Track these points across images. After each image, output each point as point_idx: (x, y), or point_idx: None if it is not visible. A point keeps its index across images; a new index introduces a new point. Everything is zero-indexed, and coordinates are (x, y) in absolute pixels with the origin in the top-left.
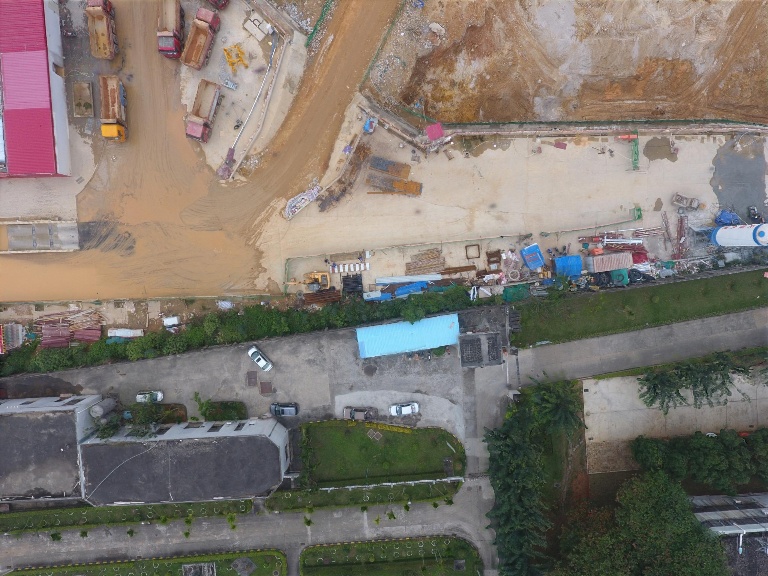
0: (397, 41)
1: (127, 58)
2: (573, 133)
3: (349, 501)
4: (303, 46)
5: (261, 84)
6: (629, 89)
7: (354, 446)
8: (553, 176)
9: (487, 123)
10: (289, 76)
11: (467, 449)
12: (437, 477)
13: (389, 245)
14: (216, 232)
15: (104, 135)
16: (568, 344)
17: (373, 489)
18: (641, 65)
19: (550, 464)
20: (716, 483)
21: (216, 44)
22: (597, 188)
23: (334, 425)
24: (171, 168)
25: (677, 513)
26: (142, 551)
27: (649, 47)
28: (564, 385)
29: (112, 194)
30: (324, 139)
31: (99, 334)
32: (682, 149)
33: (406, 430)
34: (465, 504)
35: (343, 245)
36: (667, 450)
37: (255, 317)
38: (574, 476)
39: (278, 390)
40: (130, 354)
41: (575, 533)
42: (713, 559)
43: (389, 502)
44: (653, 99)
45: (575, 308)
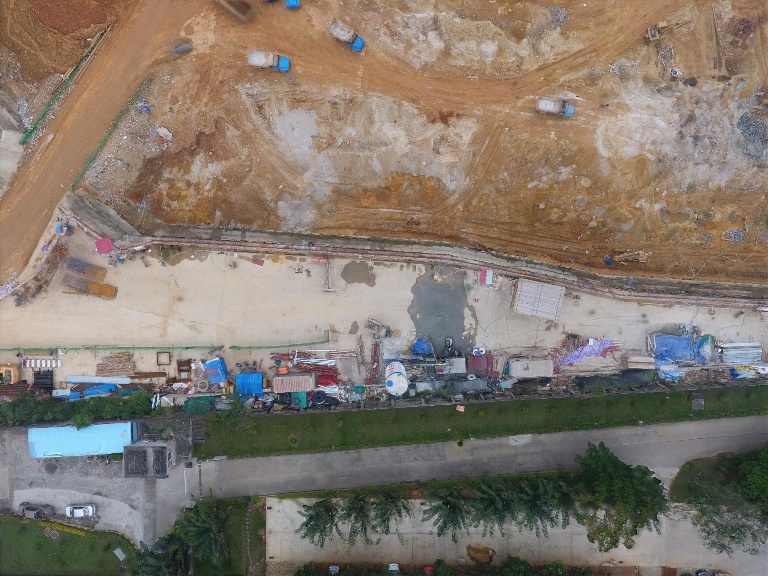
0: (119, 144)
1: None
2: (271, 251)
3: None
4: (18, 144)
5: None
6: (384, 198)
7: (30, 543)
8: (249, 291)
9: (207, 228)
10: None
11: None
12: None
13: (82, 345)
14: None
15: None
16: (252, 460)
17: None
18: (389, 178)
19: None
20: None
21: None
22: (293, 306)
23: (7, 521)
24: None
25: None
26: None
27: (392, 163)
28: (243, 501)
29: None
30: (30, 235)
31: None
32: (381, 275)
33: (80, 532)
34: None
35: (37, 340)
36: None
37: None
38: None
39: None
40: None
41: None
42: None
43: None
44: (409, 209)
45: (261, 424)
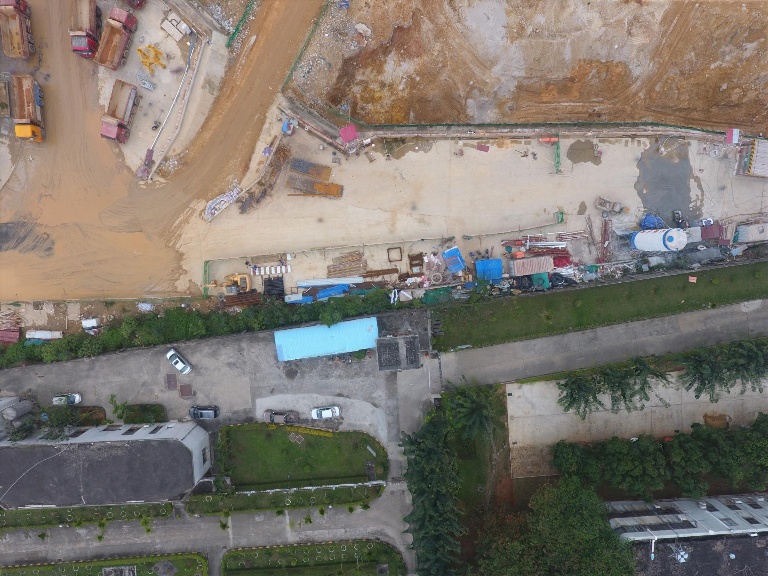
0: (321, 42)
1: (44, 58)
2: (495, 136)
3: (270, 505)
4: (224, 46)
5: (179, 85)
6: (565, 91)
7: (275, 449)
8: (476, 179)
9: (414, 125)
10: (208, 77)
11: (390, 453)
12: (359, 481)
13: (310, 247)
14: (136, 234)
15: (18, 135)
16: (491, 348)
17: (295, 493)
18: (575, 67)
19: (474, 468)
20: (631, 489)
21: (134, 44)
22: (520, 191)
23: (254, 428)
24: (90, 169)
25: (585, 519)
26: (62, 554)
27: (582, 49)
28: (486, 389)
29: (30, 195)
30: (245, 140)
31: (17, 336)
32: (606, 152)
33: (327, 434)
34: (388, 508)
35: (264, 247)
36: (583, 455)
37: (175, 319)
38: (498, 480)
39: (198, 393)
40: (45, 356)
41: (490, 538)
42: (620, 565)
43: (310, 506)
44: (590, 101)
45: (498, 312)
